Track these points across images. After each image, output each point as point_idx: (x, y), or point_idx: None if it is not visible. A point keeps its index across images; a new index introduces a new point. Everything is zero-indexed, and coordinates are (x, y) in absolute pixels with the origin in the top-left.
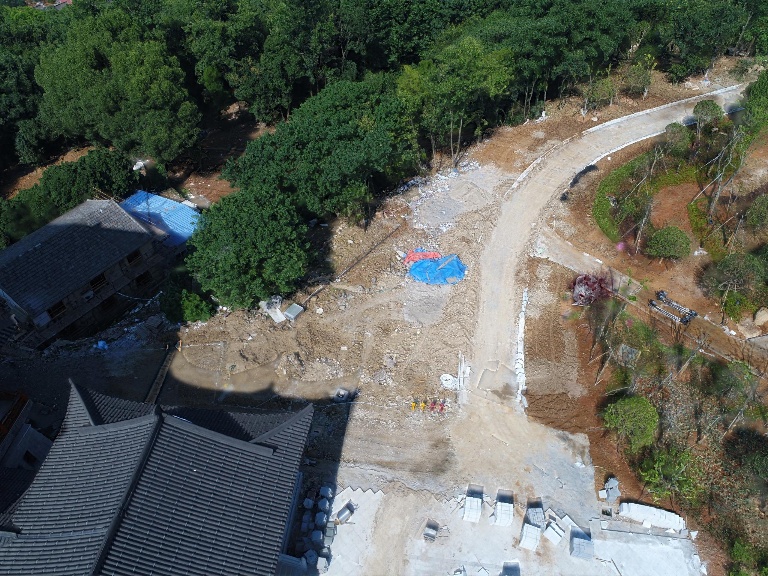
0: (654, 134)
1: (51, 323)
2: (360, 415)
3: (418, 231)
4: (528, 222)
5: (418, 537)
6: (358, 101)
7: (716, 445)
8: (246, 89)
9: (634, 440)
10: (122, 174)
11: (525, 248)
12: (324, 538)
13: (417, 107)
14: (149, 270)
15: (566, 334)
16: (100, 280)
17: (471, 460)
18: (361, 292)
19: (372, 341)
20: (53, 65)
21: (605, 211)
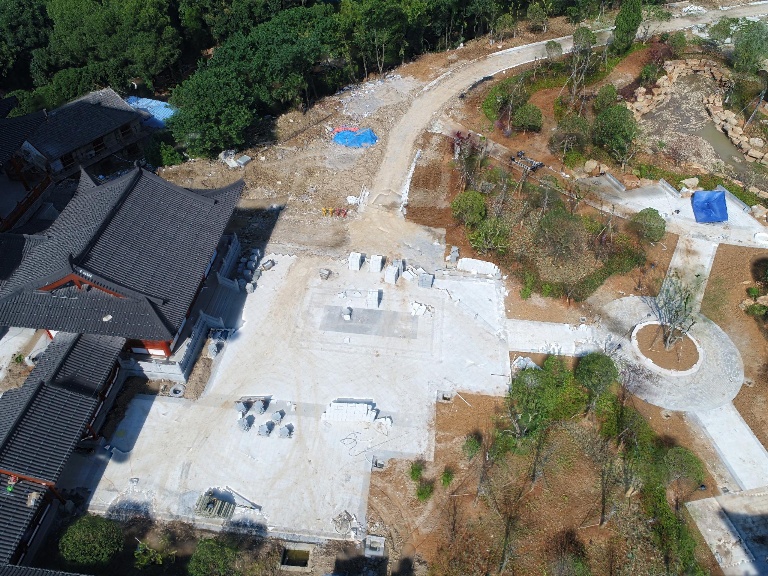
0: (545, 57)
1: (63, 171)
2: (286, 218)
3: (345, 116)
4: (431, 111)
5: (317, 277)
6: (302, 21)
7: (532, 230)
8: (220, 27)
9: (467, 217)
10: (117, 80)
11: (425, 126)
12: (252, 276)
13: (348, 26)
14: (138, 144)
15: (443, 175)
16: (100, 144)
17: (360, 241)
18: (296, 150)
19: (300, 178)
20: (62, 1)
21: (491, 103)
